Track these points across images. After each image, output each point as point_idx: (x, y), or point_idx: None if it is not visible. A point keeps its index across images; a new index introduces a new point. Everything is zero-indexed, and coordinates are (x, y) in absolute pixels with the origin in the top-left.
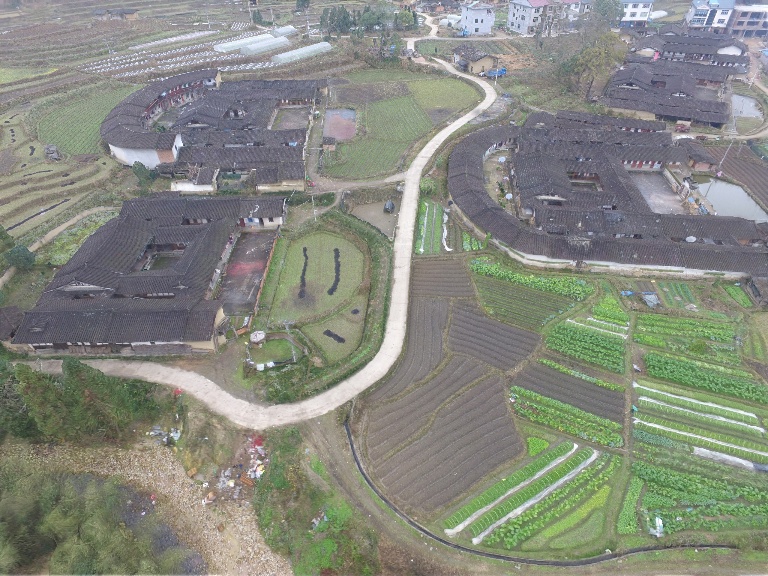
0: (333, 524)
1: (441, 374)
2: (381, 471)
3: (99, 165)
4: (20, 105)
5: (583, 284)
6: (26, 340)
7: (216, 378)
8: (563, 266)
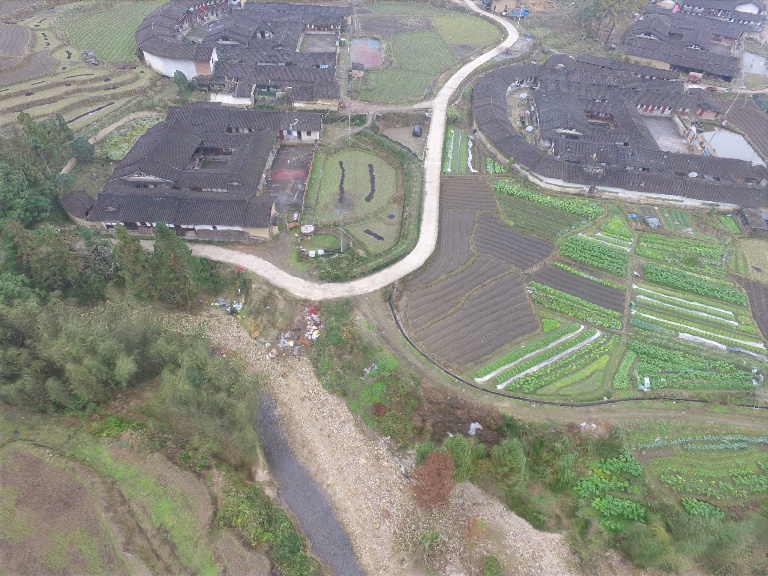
0: (383, 371)
1: (469, 269)
2: (421, 336)
3: (137, 73)
4: (46, 10)
5: (594, 206)
6: (102, 217)
7: (273, 260)
8: (577, 191)
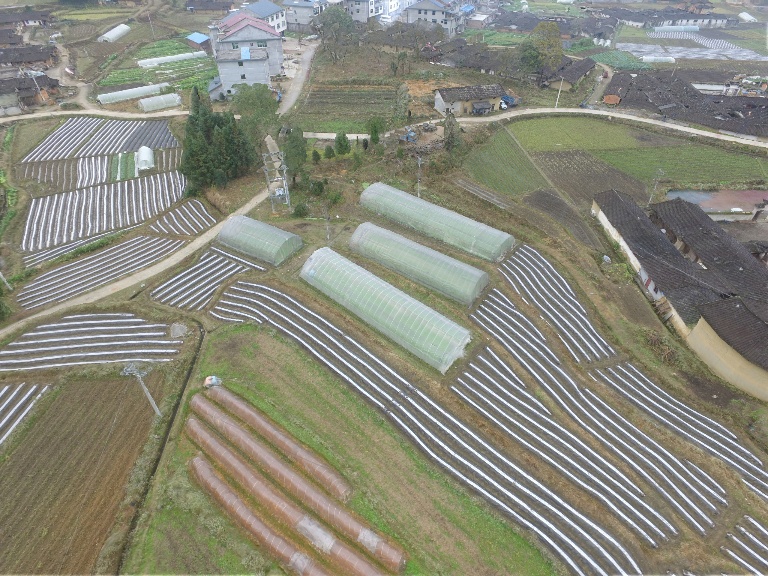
0: None
1: None
2: None
3: None
4: None
5: None
6: None
7: None
8: None
